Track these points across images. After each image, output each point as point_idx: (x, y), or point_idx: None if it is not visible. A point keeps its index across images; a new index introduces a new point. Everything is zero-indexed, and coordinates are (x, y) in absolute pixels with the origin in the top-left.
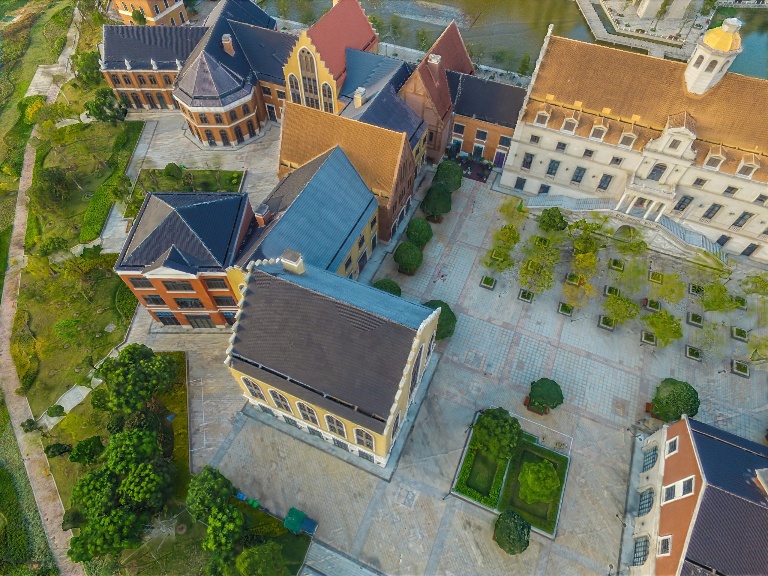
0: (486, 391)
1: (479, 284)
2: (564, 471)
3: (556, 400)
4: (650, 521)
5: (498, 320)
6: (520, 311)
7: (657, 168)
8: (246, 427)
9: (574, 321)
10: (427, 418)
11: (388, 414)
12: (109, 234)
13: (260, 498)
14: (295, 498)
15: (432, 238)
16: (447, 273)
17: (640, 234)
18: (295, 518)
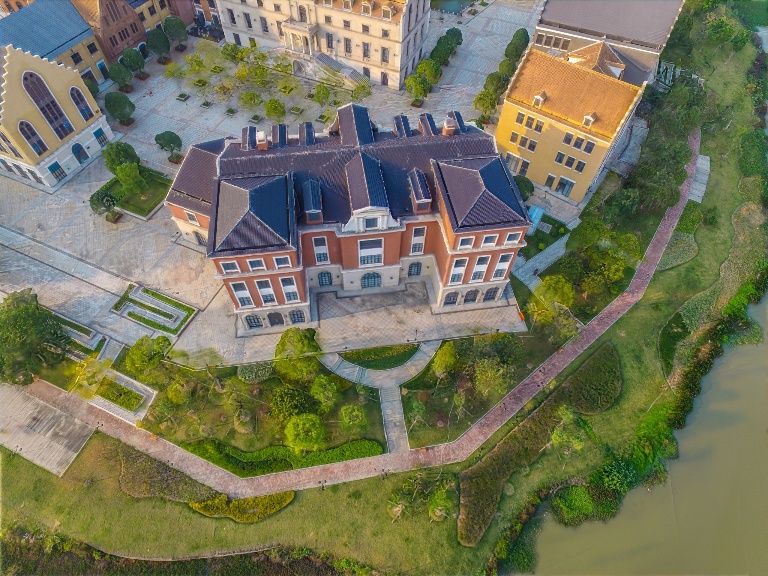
0: (146, 152)
1: (176, 98)
2: None
3: (170, 142)
4: None
5: (178, 117)
6: (197, 113)
7: (302, 11)
8: None
9: (233, 118)
10: (96, 165)
11: (1, 109)
12: None
13: None
14: None
15: (157, 73)
16: (156, 92)
17: (306, 68)
18: None
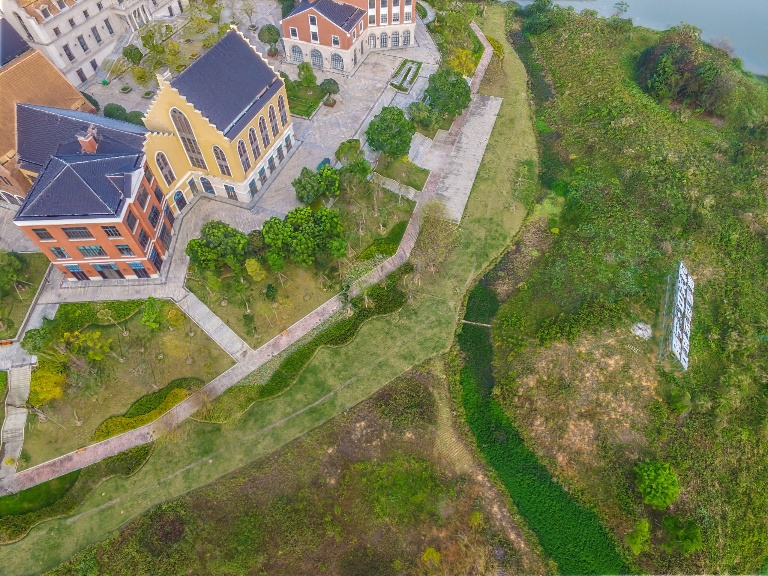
0: None
1: None
2: None
3: None
4: (325, 53)
5: None
6: None
7: None
8: (263, 206)
9: None
10: None
11: (274, 73)
12: (5, 363)
13: None
14: None
15: None
16: None
17: (155, 35)
18: (322, 165)
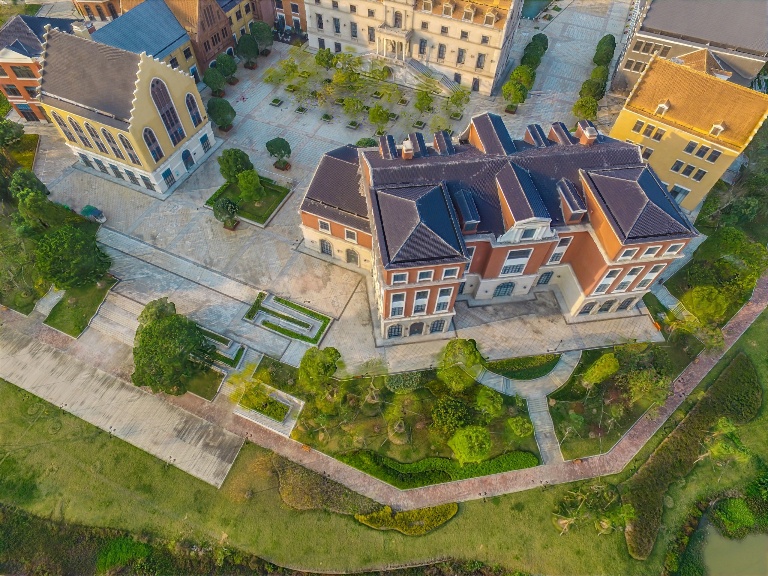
0: (250, 159)
1: (269, 103)
2: (284, 195)
3: (282, 149)
4: None
5: (275, 123)
6: (293, 118)
7: (397, 16)
8: (72, 174)
9: (330, 124)
10: (202, 171)
11: (130, 116)
12: None
13: (72, 207)
14: (96, 207)
15: (245, 78)
16: (248, 97)
17: (397, 73)
18: (87, 208)
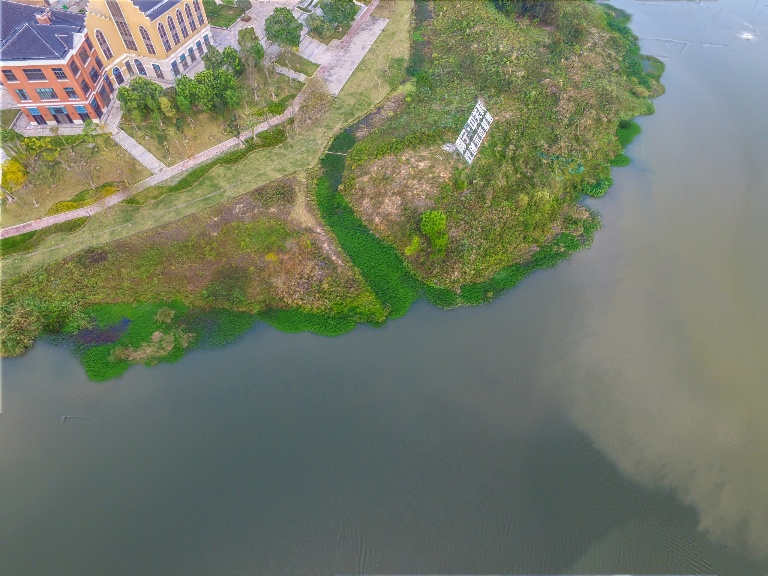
0: None
1: None
2: None
3: None
4: None
5: None
6: None
7: None
8: None
9: None
10: None
11: None
12: None
13: None
14: None
15: None
16: None
17: None
18: None
